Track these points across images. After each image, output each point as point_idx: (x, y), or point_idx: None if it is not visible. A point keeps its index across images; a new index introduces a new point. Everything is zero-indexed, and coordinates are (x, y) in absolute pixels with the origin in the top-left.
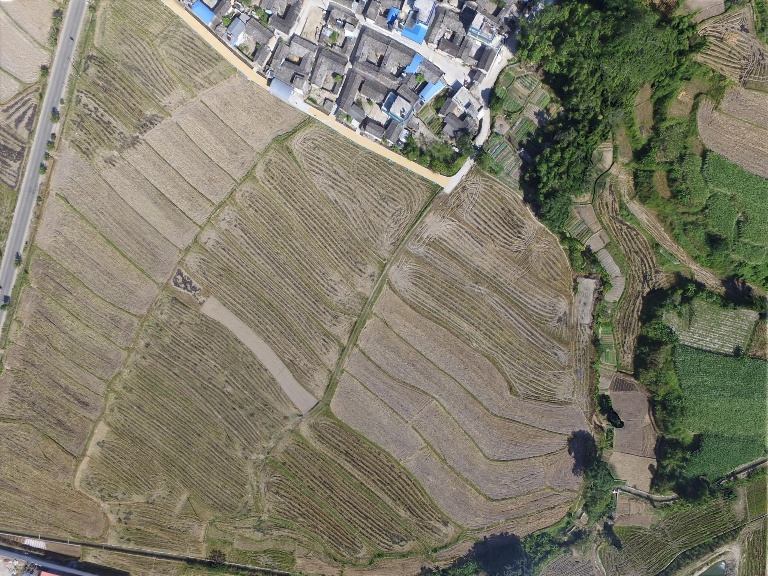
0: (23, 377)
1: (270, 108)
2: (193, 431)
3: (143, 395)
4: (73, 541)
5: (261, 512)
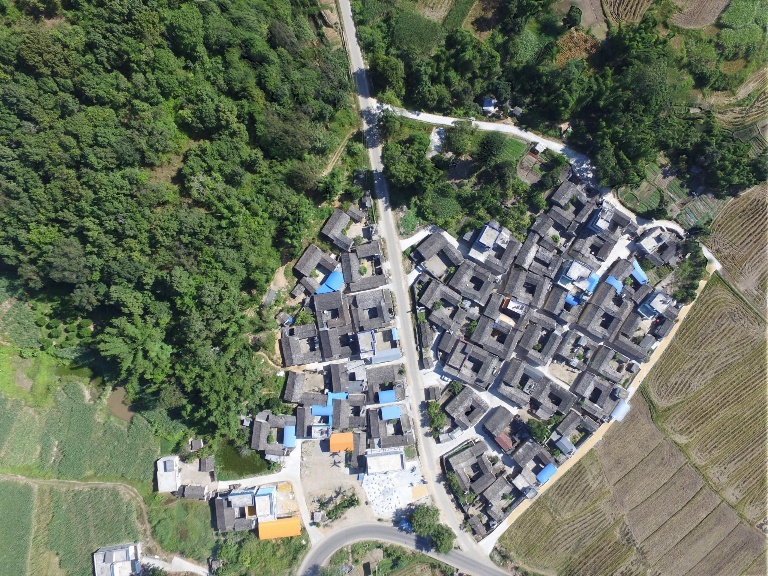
0: None
1: (627, 422)
2: None
3: None
4: None
5: None
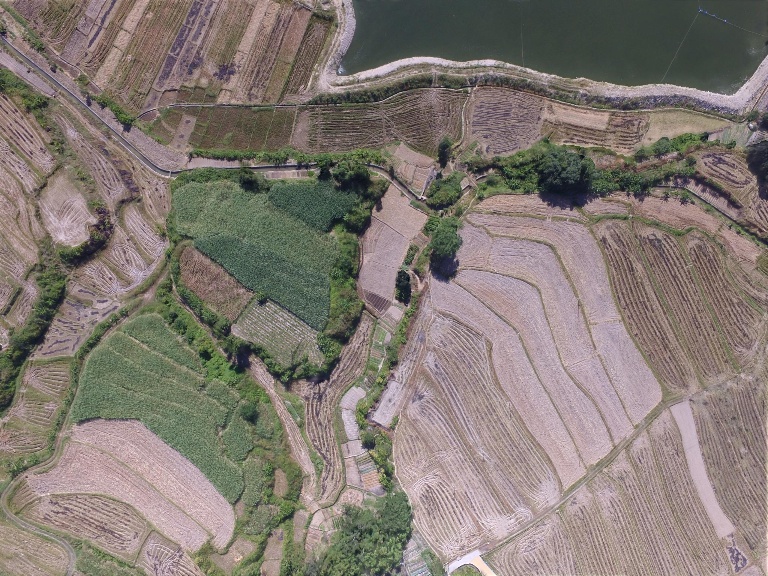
0: None
1: None
2: None
3: None
4: None
5: (767, 323)
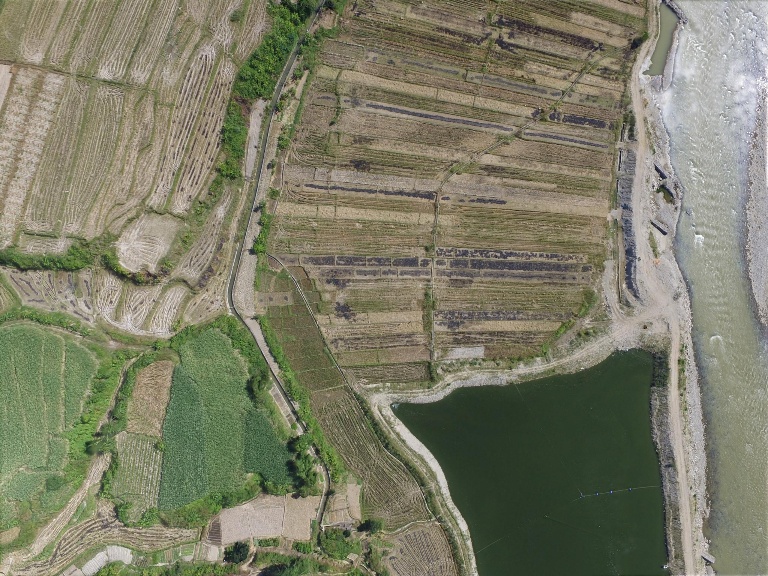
0: None
1: None
2: None
3: None
4: None
5: None
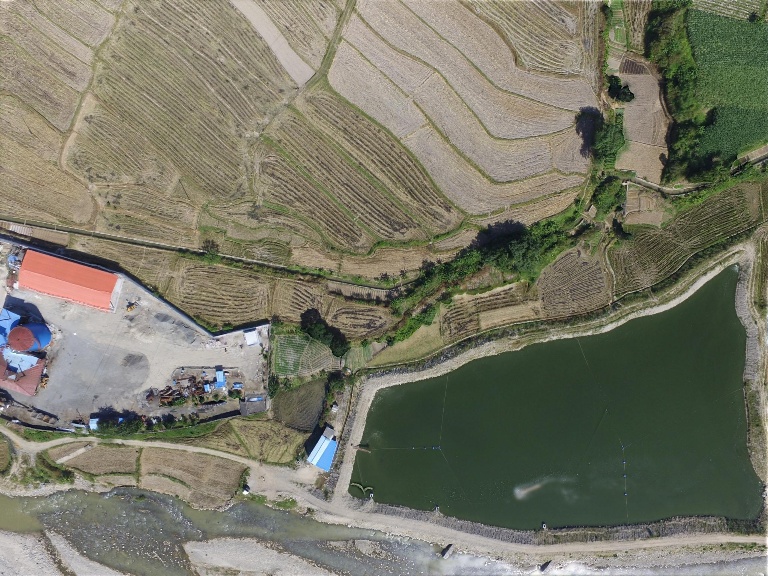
0: (7, 44)
1: None
2: (185, 105)
3: (132, 65)
4: (60, 229)
5: (256, 195)
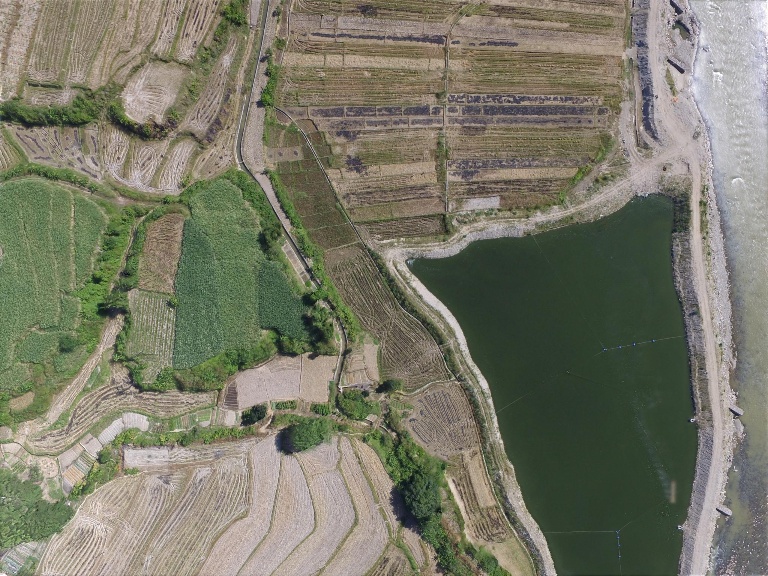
0: None
1: None
2: None
3: None
4: None
5: None
